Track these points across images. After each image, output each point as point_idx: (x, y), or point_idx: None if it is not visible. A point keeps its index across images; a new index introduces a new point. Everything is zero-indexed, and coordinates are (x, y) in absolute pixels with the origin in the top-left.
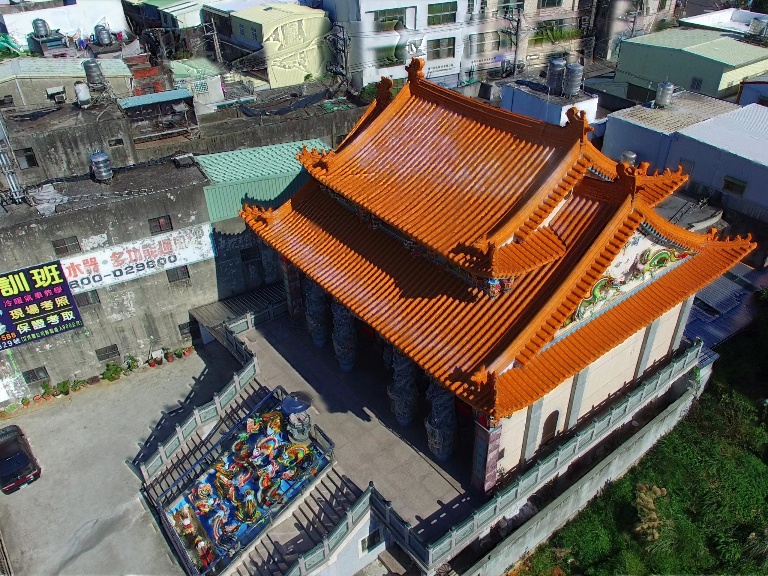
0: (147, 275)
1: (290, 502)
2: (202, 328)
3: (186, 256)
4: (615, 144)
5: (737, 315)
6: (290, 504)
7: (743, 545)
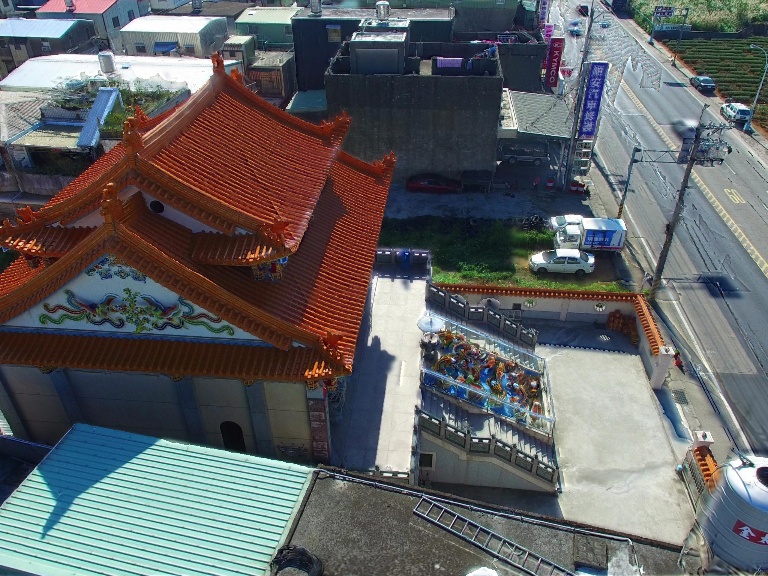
0: None
1: None
2: None
3: None
4: None
5: None
6: None
7: None
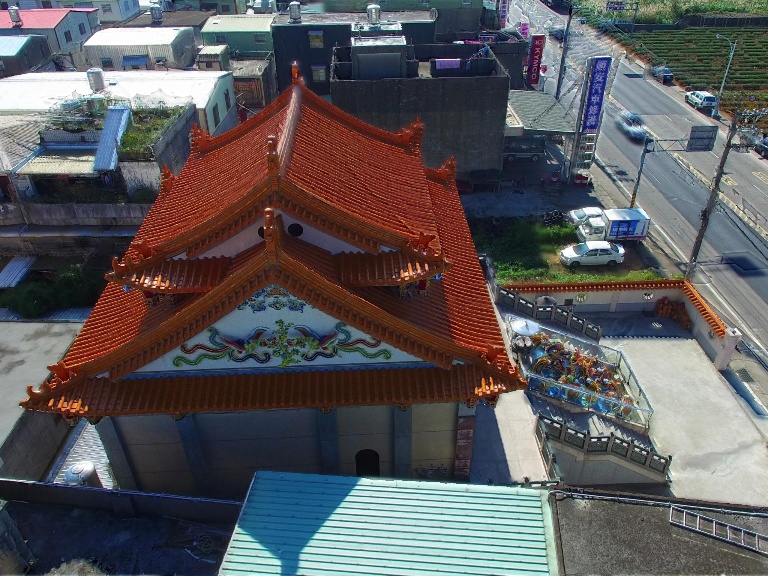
0: None
1: None
2: None
3: None
4: None
5: (73, 315)
6: None
7: None
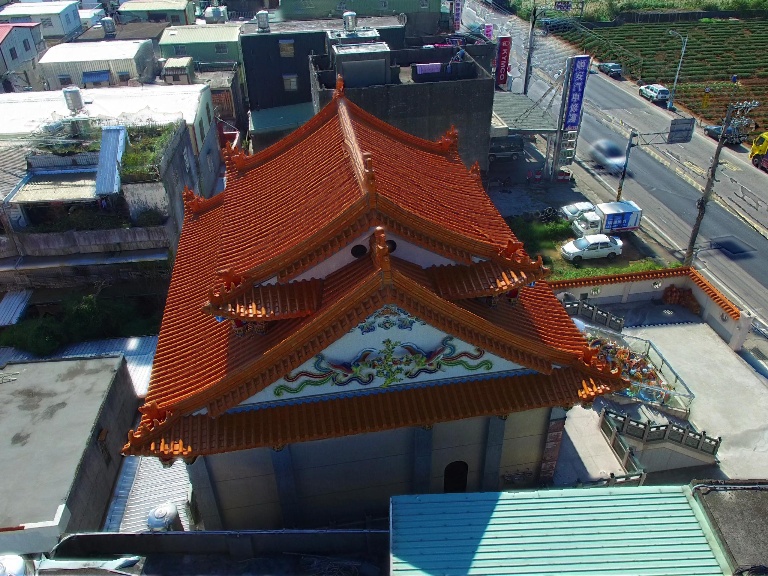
0: None
1: None
2: None
3: None
4: None
5: (89, 349)
6: None
7: None
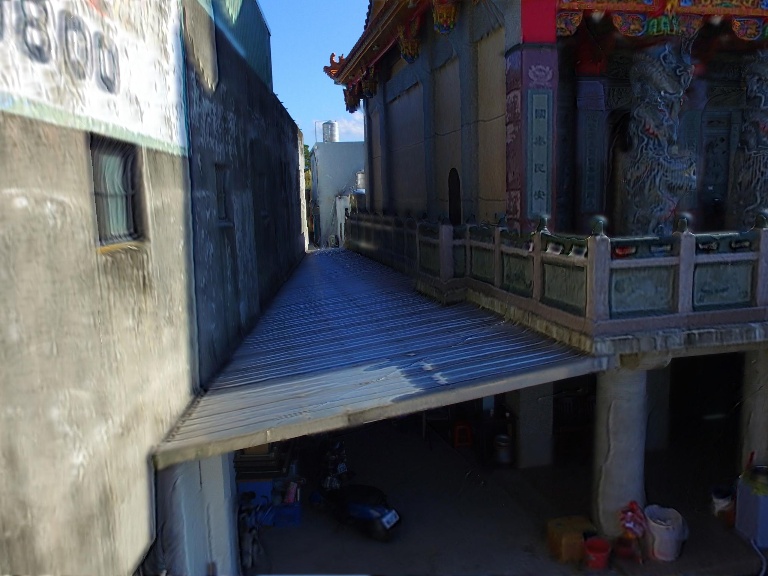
0: (13, 111)
1: None
2: (189, 564)
3: (137, 88)
4: (335, 173)
5: None
6: None
7: None
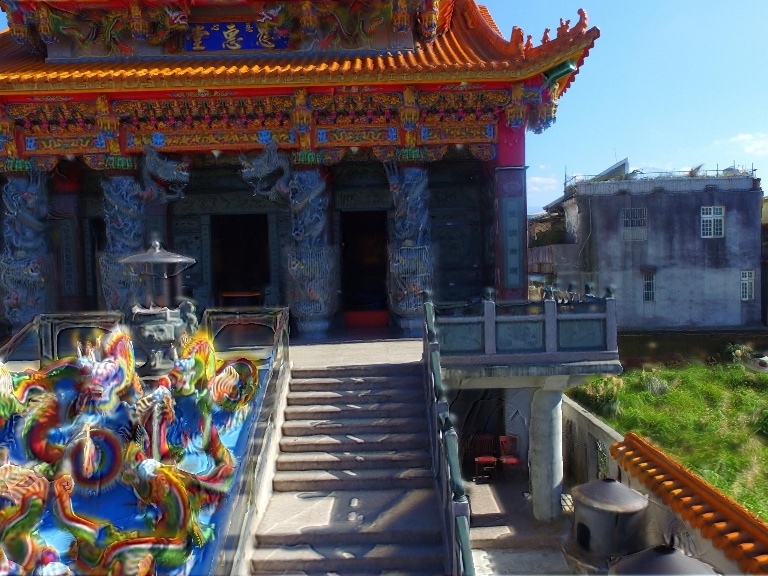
0: None
1: (258, 451)
2: None
3: None
4: None
5: None
6: (265, 450)
7: (646, 389)
